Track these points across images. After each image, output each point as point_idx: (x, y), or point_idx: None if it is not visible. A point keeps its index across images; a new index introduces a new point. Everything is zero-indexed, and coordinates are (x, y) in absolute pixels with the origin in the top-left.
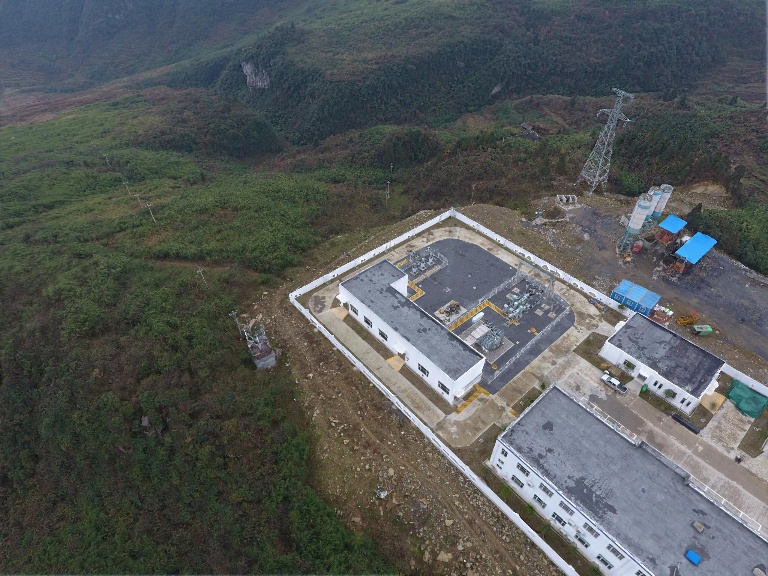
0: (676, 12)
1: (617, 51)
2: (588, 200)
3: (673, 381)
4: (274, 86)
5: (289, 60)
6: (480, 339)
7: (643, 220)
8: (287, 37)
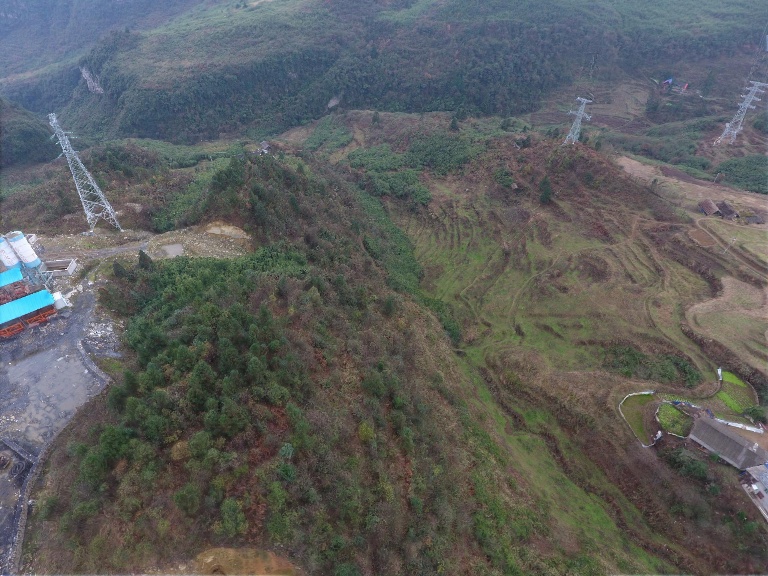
0: (517, 28)
1: (451, 67)
2: (53, 240)
3: None
4: None
5: (112, 66)
6: None
7: None
8: (119, 42)
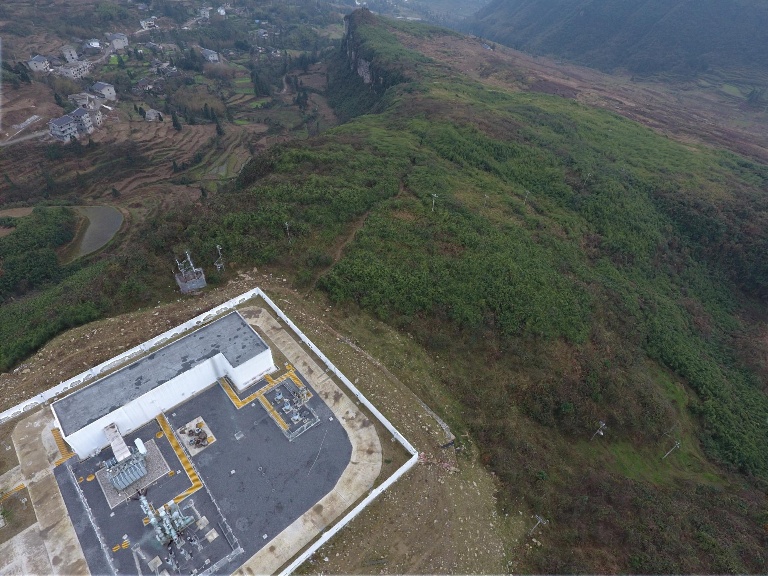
0: None
1: None
2: None
3: None
4: None
5: None
6: None
7: None
8: None
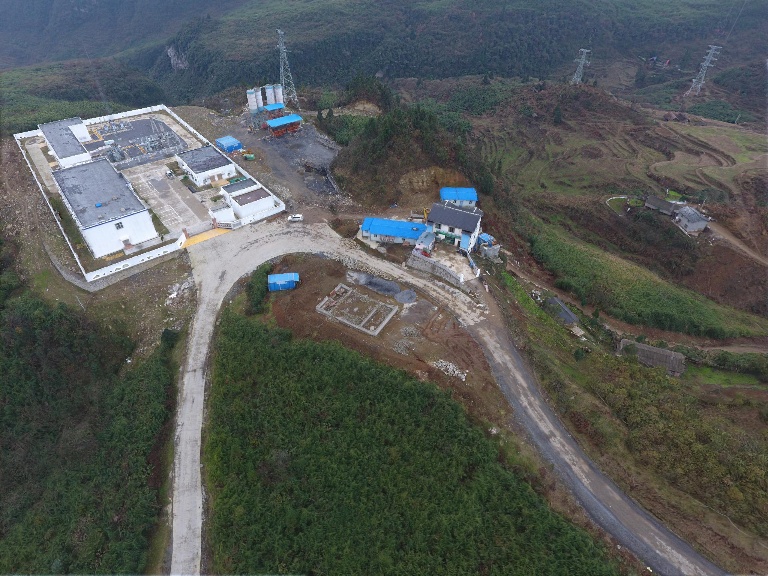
0: (530, 15)
1: (476, 46)
2: None
3: (193, 169)
4: (189, 66)
5: (199, 44)
6: (104, 152)
7: (254, 103)
8: (203, 25)
